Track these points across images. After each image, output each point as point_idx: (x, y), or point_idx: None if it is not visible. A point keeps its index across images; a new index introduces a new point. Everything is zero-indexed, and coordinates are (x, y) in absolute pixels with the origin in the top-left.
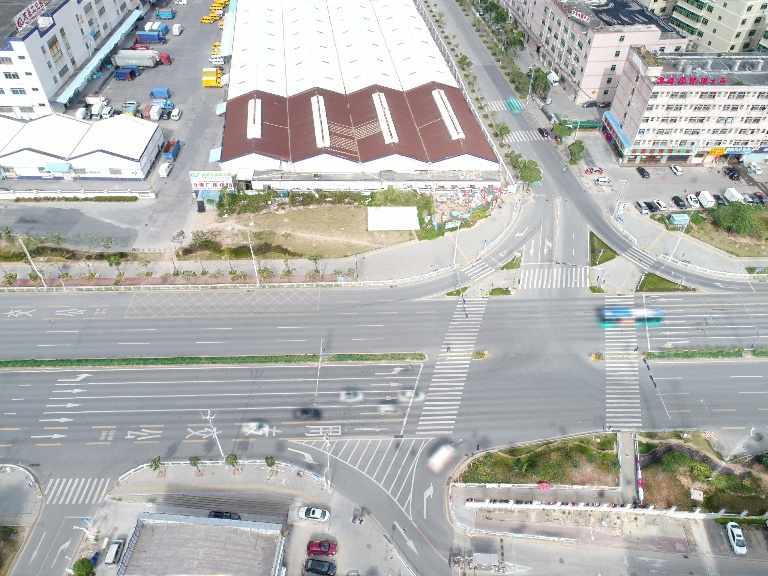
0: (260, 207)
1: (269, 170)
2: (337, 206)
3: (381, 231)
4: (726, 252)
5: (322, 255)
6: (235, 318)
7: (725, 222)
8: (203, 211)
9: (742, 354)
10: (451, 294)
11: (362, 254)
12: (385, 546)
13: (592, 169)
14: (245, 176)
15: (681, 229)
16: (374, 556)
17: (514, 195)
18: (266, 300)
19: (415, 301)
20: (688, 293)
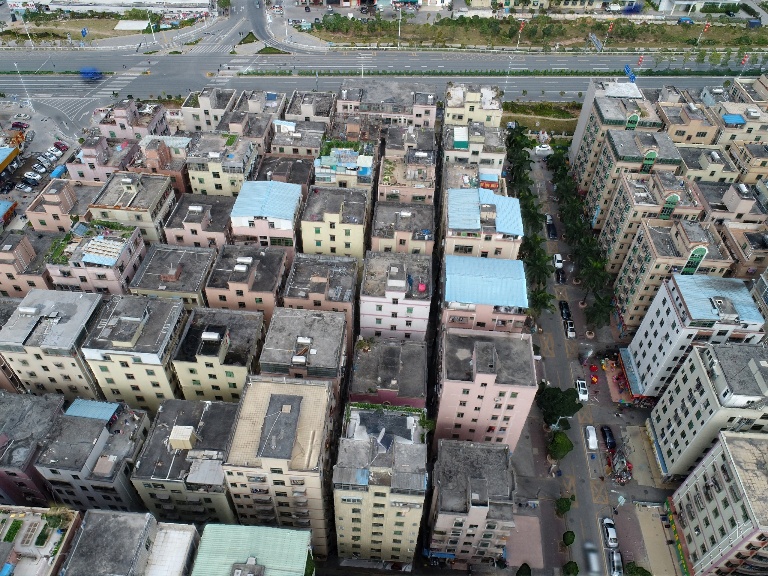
0: (50, 18)
1: (62, 1)
2: (101, 19)
3: (121, 30)
4: (324, 40)
5: (79, 38)
6: (14, 60)
7: (325, 23)
8: (15, 21)
9: (292, 74)
10: (146, 53)
11: (104, 38)
12: (53, 127)
13: (274, 6)
14: (45, 2)
15: (306, 31)
16: (46, 129)
17: (216, 17)
18: (36, 55)
19: (124, 56)
20: (286, 55)
